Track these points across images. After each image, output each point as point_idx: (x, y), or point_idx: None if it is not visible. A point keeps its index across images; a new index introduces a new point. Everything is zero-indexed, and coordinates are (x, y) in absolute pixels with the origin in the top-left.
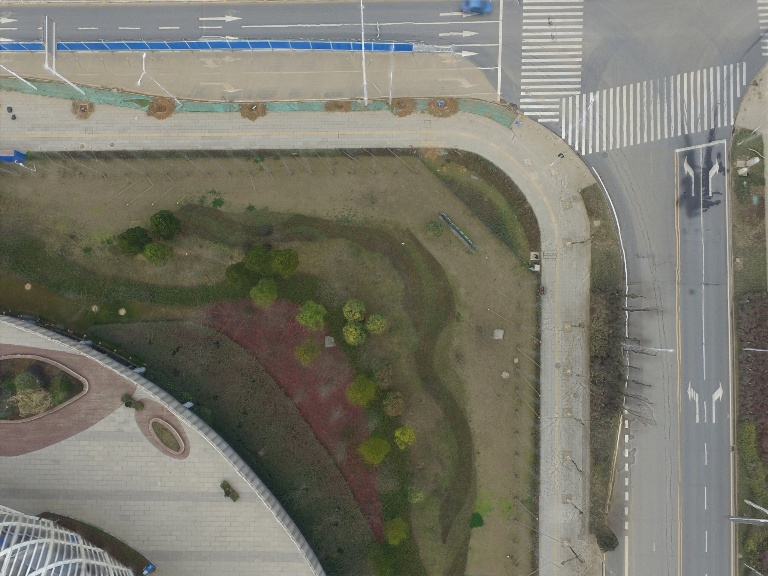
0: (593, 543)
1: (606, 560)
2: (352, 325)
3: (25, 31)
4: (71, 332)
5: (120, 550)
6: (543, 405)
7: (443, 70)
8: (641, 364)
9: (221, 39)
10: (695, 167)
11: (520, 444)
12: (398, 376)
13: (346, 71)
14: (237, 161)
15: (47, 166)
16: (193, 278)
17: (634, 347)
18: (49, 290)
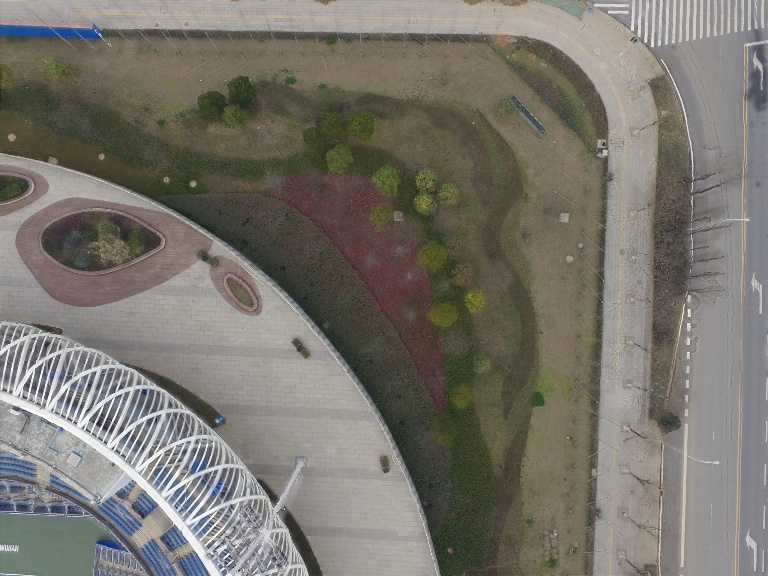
0: (653, 429)
1: (665, 447)
2: (424, 194)
3: None
4: None
5: (192, 402)
6: (606, 290)
7: None
8: (705, 254)
9: None
10: (764, 61)
11: (583, 327)
12: (465, 252)
13: None
14: (309, 43)
15: (122, 42)
16: (264, 151)
17: (704, 226)
18: (122, 160)
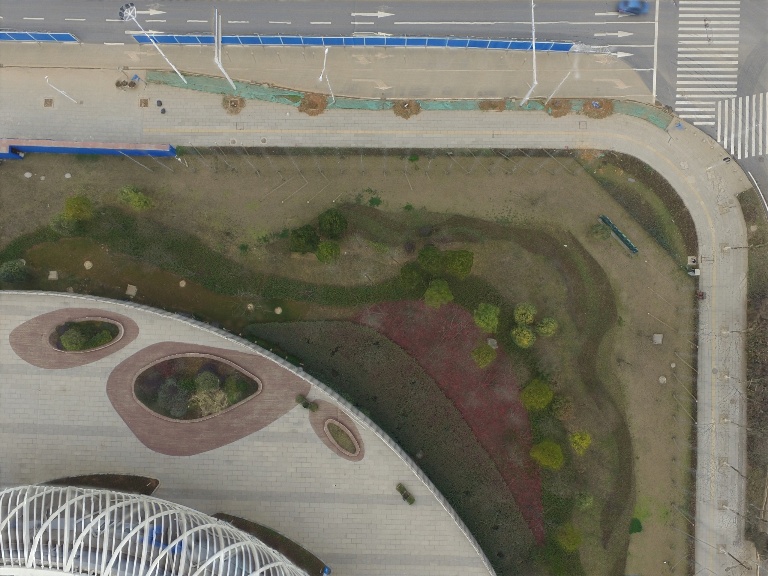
0: (748, 550)
1: (760, 567)
2: (524, 328)
3: (174, 23)
4: (227, 330)
5: (295, 552)
6: (700, 411)
7: (598, 71)
8: None
9: (379, 35)
10: None
11: (677, 449)
12: (561, 380)
13: (500, 70)
14: (391, 159)
15: (199, 161)
16: (352, 278)
17: None
18: (205, 287)
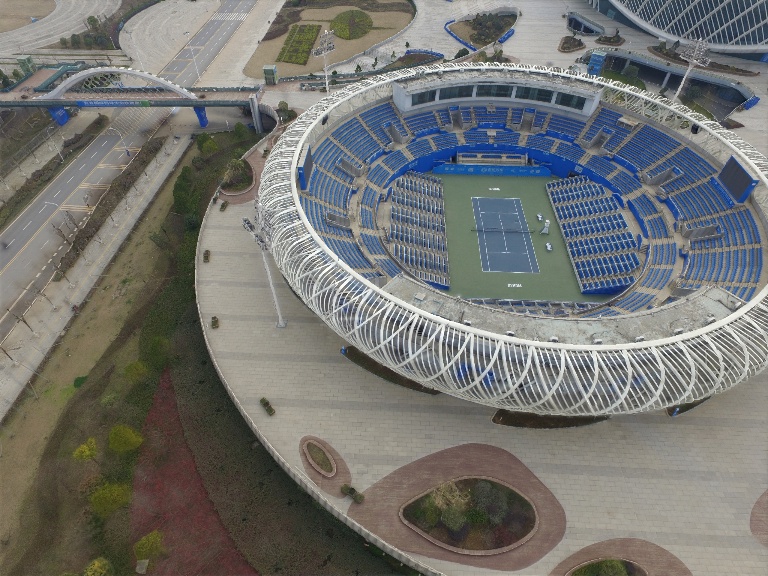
0: None
1: None
2: None
3: None
4: None
5: (369, 364)
6: None
7: None
8: None
9: None
10: None
11: (3, 446)
12: None
13: None
14: None
15: None
16: None
17: None
18: None
